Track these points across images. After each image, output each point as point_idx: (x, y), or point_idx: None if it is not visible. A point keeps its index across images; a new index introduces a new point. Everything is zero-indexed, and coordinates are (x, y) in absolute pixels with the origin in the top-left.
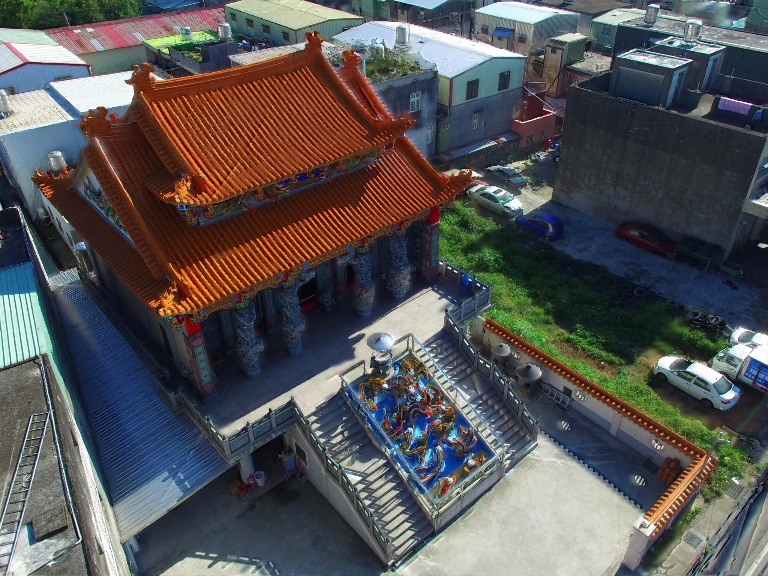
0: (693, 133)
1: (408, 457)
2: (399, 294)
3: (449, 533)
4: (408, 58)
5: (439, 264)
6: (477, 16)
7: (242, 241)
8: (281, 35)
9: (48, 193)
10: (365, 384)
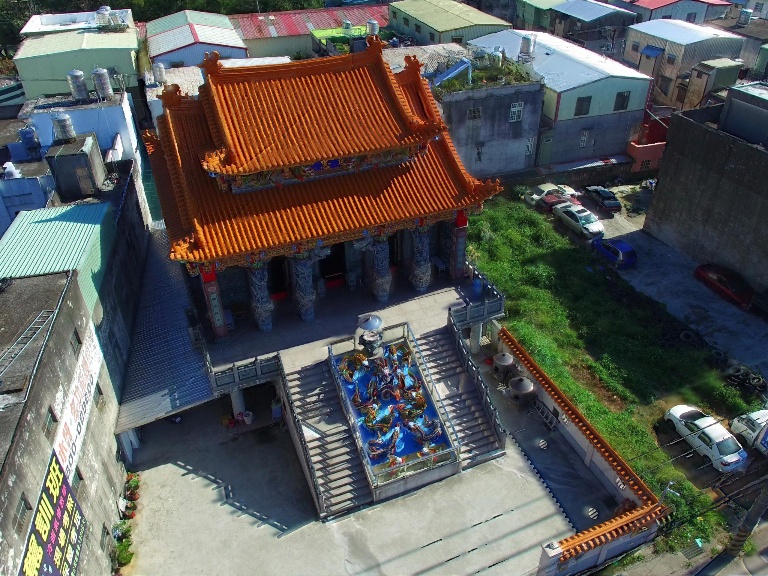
0: None
1: (370, 430)
2: (419, 287)
3: (386, 506)
4: (520, 68)
5: (469, 267)
6: (630, 32)
7: (263, 211)
8: (428, 35)
9: (150, 150)
10: (350, 357)
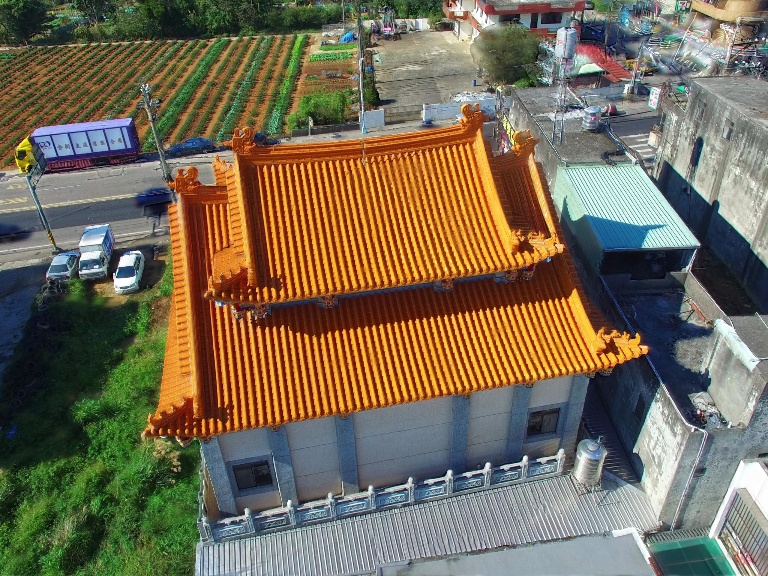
0: None
1: None
2: None
3: None
4: None
5: None
6: None
7: None
8: None
9: None
10: None
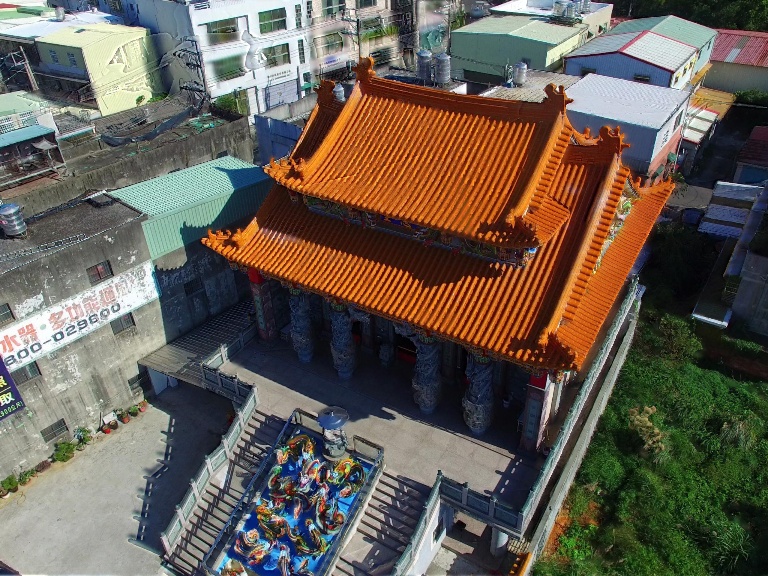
0: None
1: None
2: None
3: None
4: None
5: None
6: None
7: (315, 240)
8: None
9: None
10: None
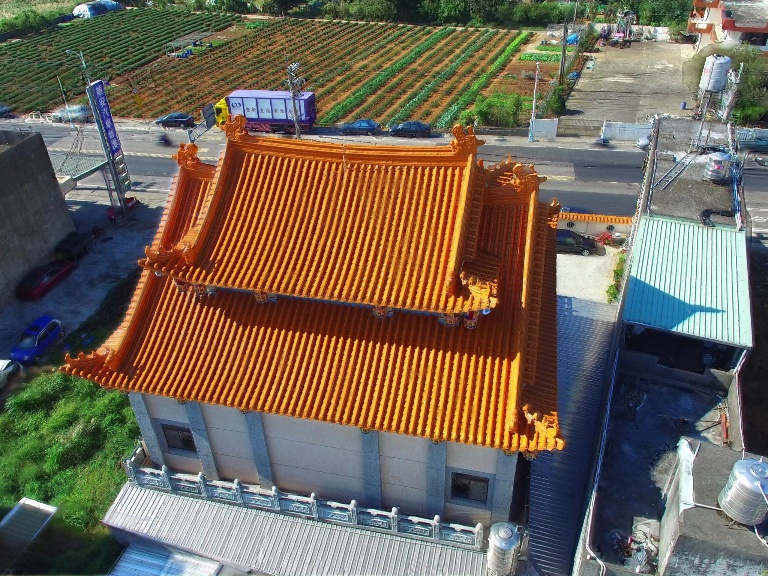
0: (2, 169)
1: None
2: None
3: None
4: None
5: None
6: None
7: None
8: None
9: None
10: None
